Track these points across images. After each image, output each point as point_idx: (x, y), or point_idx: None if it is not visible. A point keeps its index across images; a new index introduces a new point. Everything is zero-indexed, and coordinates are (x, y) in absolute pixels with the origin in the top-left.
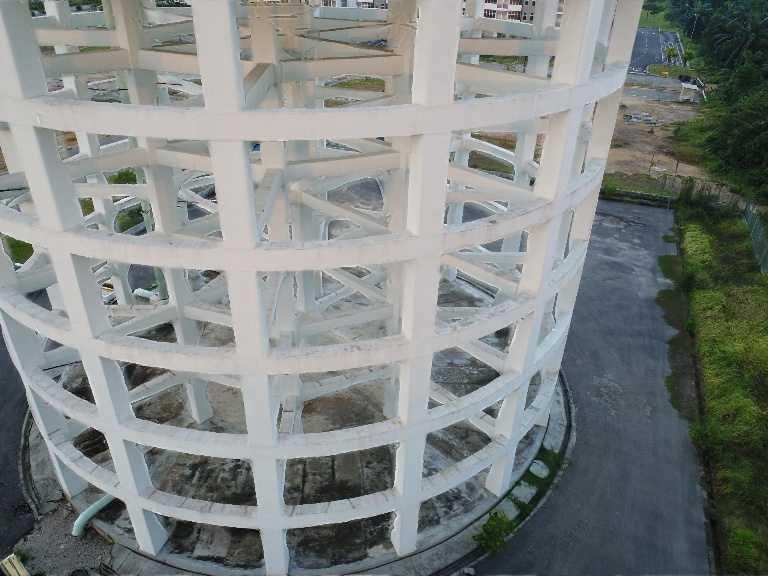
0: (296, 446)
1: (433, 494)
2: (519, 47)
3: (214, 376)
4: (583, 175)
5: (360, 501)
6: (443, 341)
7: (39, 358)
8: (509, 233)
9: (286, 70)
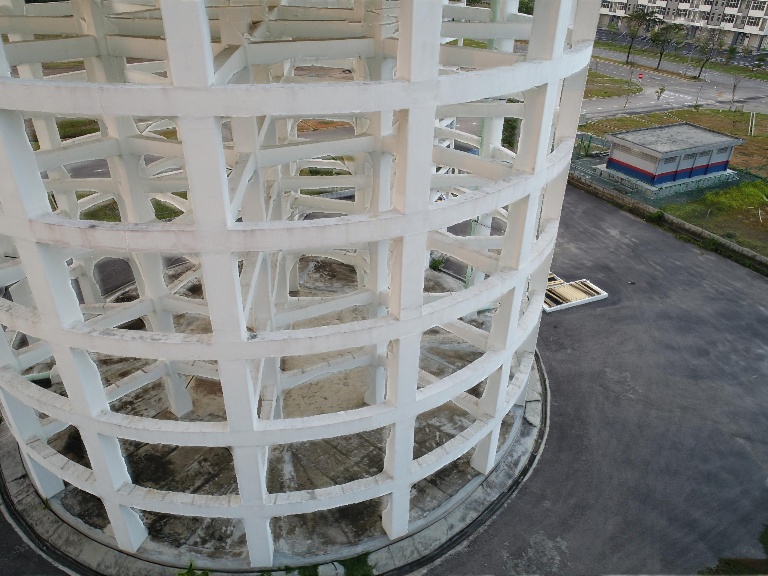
0: (2, 379)
1: (132, 504)
2: (446, 56)
3: (150, 320)
4: (315, 220)
5: (72, 467)
6: (76, 339)
7: (8, 247)
8: (119, 247)
9: (112, 44)
